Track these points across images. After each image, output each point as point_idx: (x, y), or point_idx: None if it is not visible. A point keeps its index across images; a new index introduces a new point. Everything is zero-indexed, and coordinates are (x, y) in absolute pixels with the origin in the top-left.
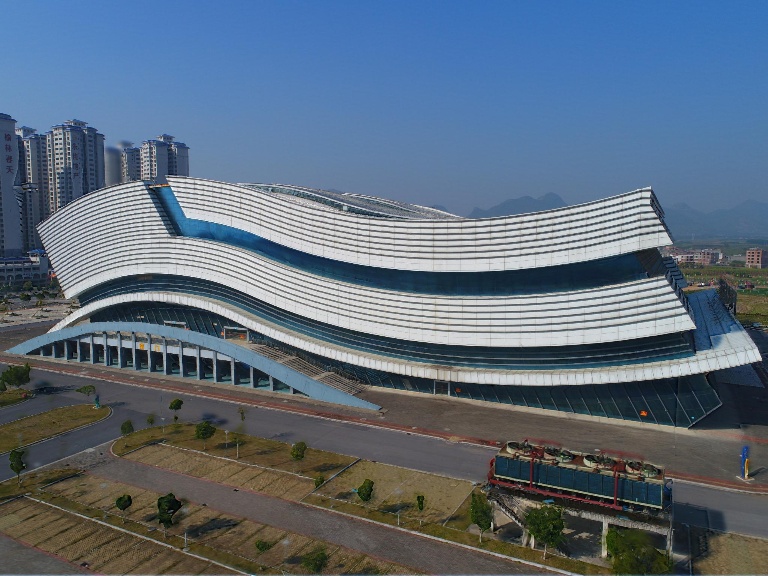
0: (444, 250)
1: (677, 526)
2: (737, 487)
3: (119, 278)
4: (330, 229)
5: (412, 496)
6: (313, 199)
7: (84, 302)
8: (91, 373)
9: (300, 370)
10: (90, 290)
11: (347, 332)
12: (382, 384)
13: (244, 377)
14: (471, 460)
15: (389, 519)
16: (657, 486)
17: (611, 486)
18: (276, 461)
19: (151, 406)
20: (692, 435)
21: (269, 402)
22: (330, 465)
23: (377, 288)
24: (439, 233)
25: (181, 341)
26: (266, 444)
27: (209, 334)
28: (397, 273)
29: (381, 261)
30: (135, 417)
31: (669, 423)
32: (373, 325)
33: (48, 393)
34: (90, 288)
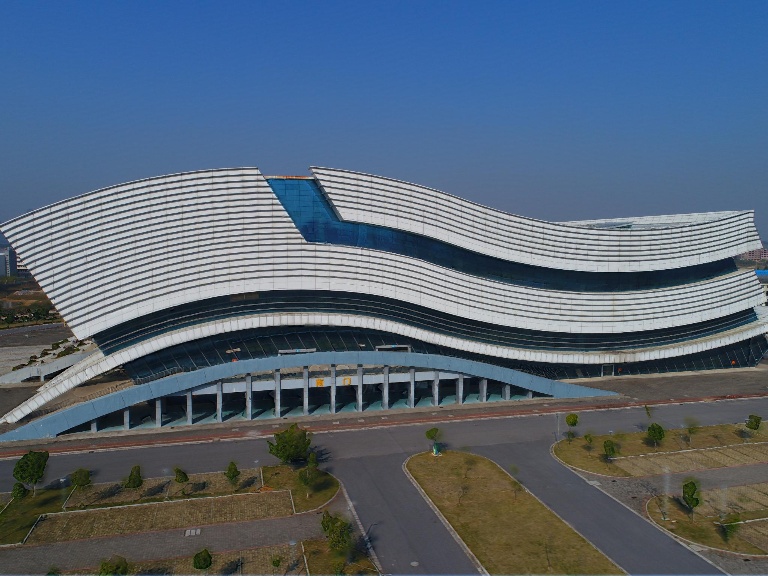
0: (628, 254)
1: None
2: None
3: None
4: (528, 235)
5: None
6: None
7: (109, 341)
8: (268, 431)
9: None
10: (124, 322)
11: (525, 334)
12: None
13: (445, 395)
14: (758, 408)
15: None
16: None
17: None
18: (713, 441)
19: (475, 438)
20: None
21: (539, 409)
22: (738, 432)
23: None
24: (624, 240)
25: (389, 366)
26: None
27: None
28: (578, 275)
29: (576, 265)
30: (504, 450)
31: (746, 366)
32: (560, 324)
33: (319, 460)
34: None
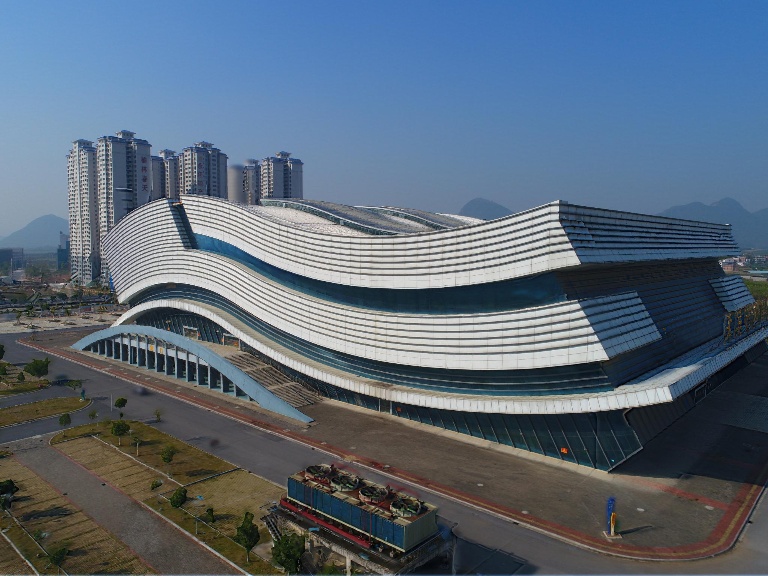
0: (379, 266)
1: (468, 575)
2: (590, 543)
3: (154, 286)
4: (292, 244)
5: (243, 509)
6: (317, 214)
7: (132, 306)
8: (111, 370)
9: (265, 378)
10: (136, 296)
11: (311, 344)
12: (338, 397)
13: None
14: None
15: (195, 528)
16: (400, 527)
17: (367, 521)
18: (164, 462)
19: None
20: (606, 480)
21: (222, 407)
22: (205, 471)
23: (334, 302)
24: (375, 249)
25: (175, 345)
26: (175, 446)
27: (213, 340)
28: (347, 288)
29: (330, 276)
30: (101, 411)
31: (589, 464)
32: (327, 339)
33: (61, 385)
34: (135, 294)
